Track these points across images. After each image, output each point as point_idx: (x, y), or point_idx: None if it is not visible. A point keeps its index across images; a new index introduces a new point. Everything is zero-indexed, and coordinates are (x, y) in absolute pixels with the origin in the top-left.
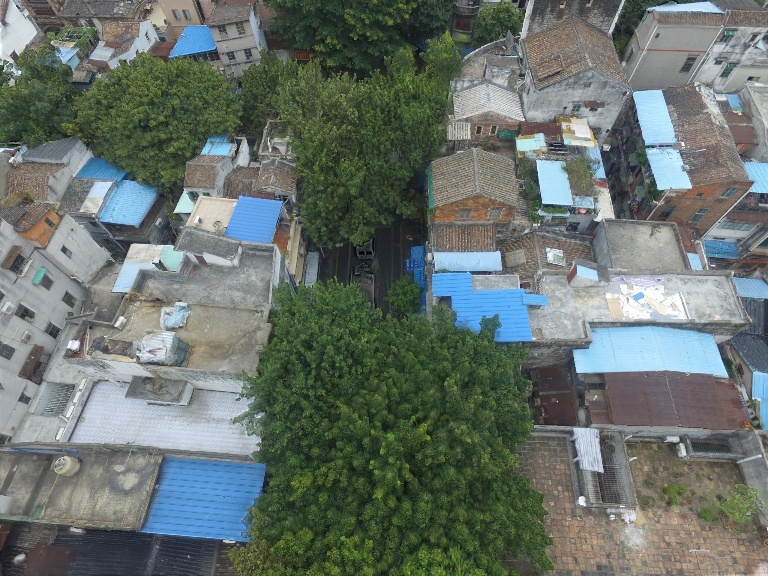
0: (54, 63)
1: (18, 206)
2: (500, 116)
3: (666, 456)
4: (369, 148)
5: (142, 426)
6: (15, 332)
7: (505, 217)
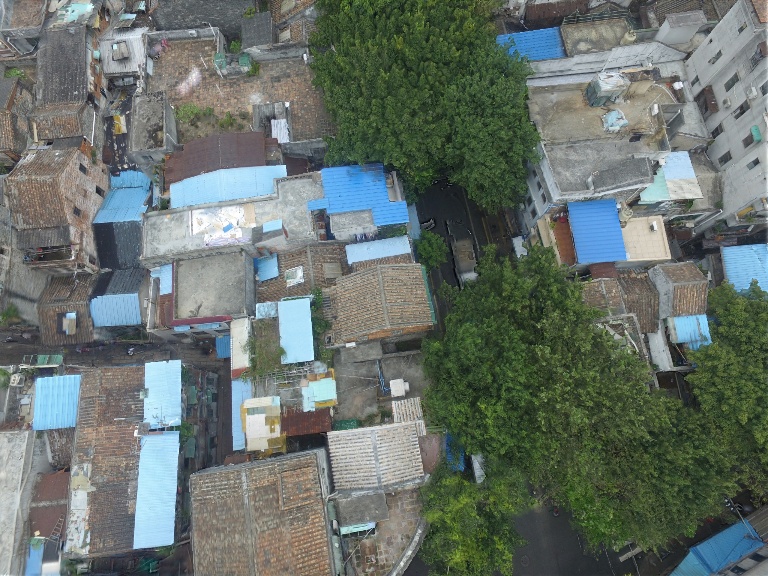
0: None
1: None
2: None
3: None
4: None
5: None
6: (736, 96)
7: None
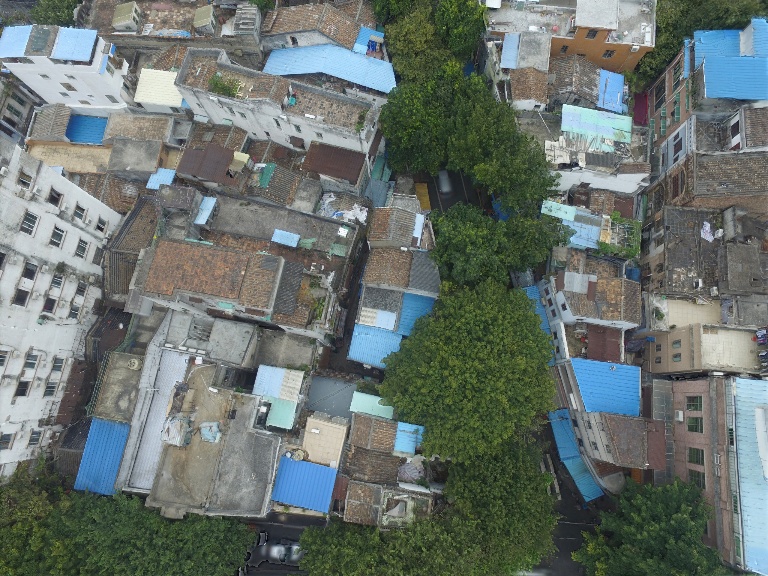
0: None
1: None
2: None
3: None
4: None
5: None
6: None
7: None
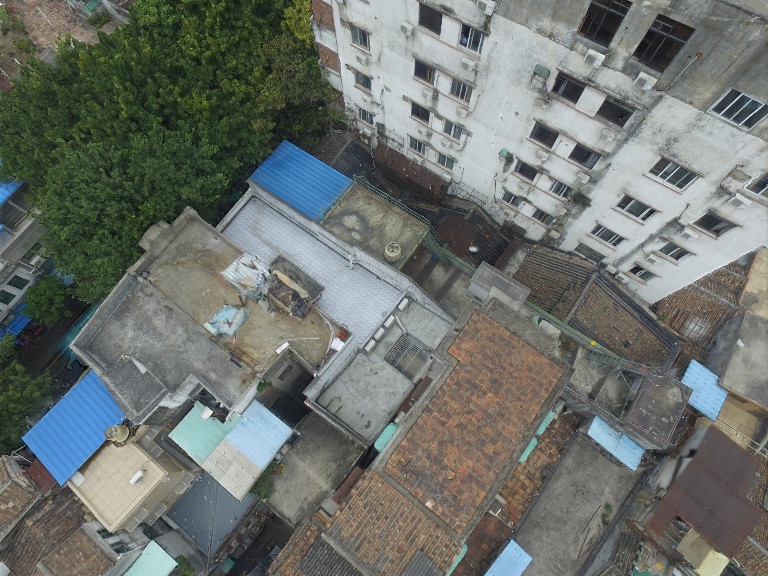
0: None
1: None
2: None
3: (4, 66)
4: None
5: (334, 277)
6: None
7: None
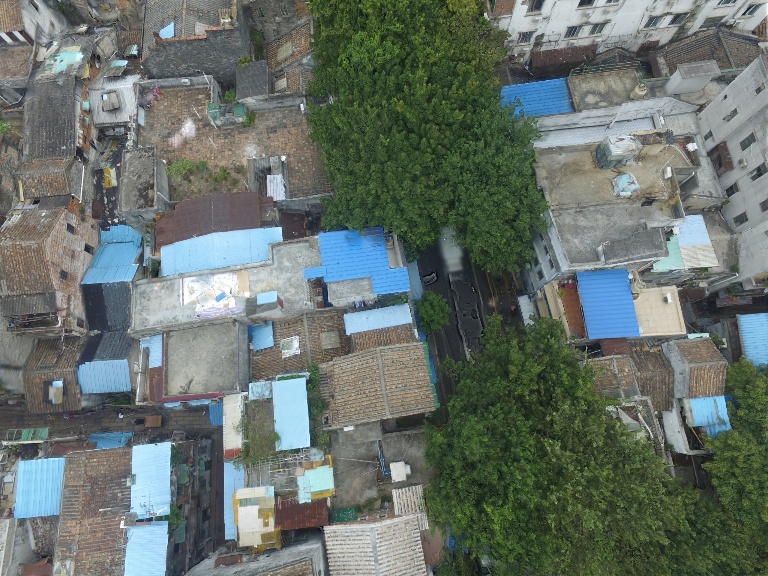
0: None
1: None
2: None
3: None
4: None
5: None
6: (753, 157)
7: None
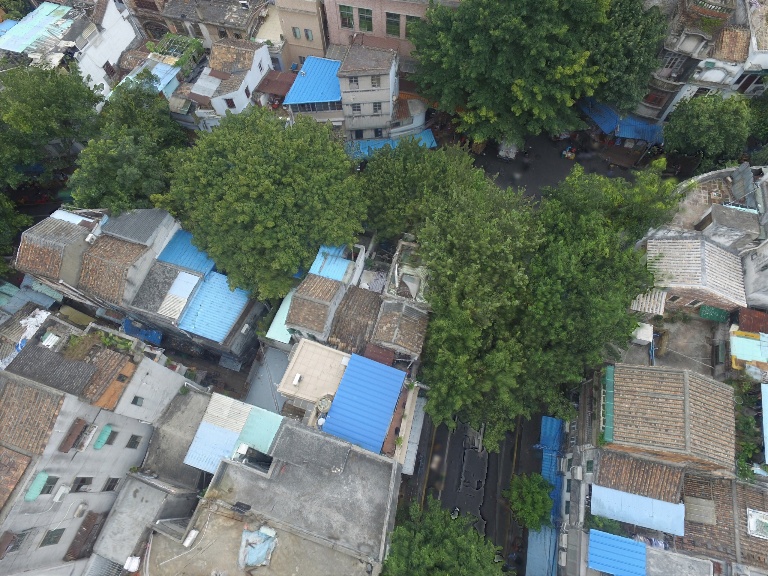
0: (150, 97)
1: (87, 354)
2: (714, 295)
3: None
4: (532, 324)
5: None
6: (67, 511)
7: (705, 467)
